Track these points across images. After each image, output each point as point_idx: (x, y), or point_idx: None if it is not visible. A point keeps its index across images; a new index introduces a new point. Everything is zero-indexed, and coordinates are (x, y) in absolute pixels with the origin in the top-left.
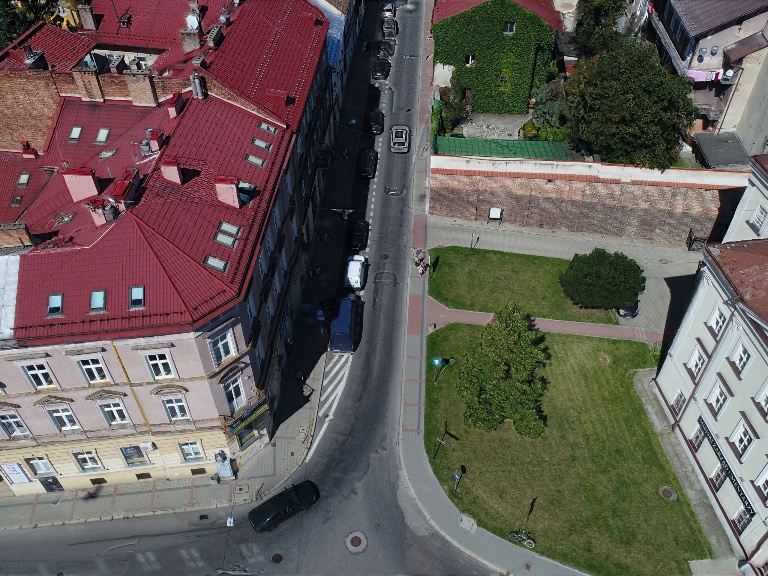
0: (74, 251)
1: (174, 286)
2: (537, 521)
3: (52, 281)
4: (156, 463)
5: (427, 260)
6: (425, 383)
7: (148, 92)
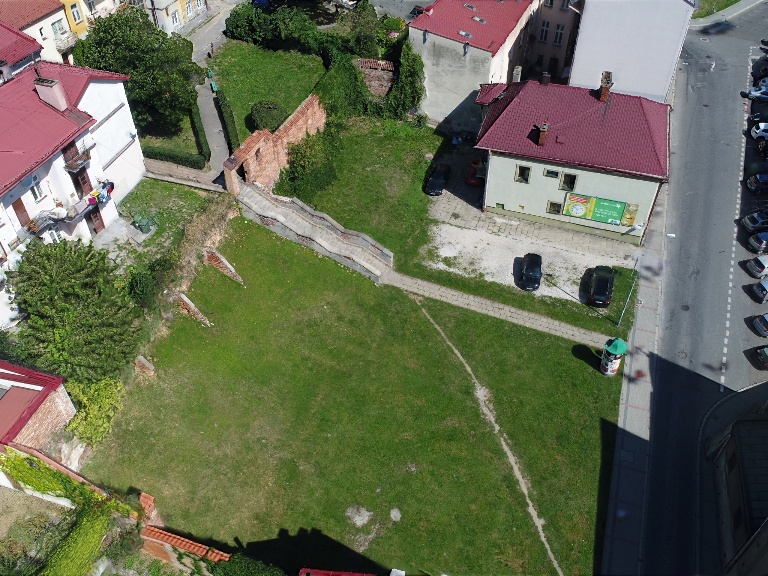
0: None
1: None
2: (704, 7)
3: None
4: None
5: None
6: None
7: None
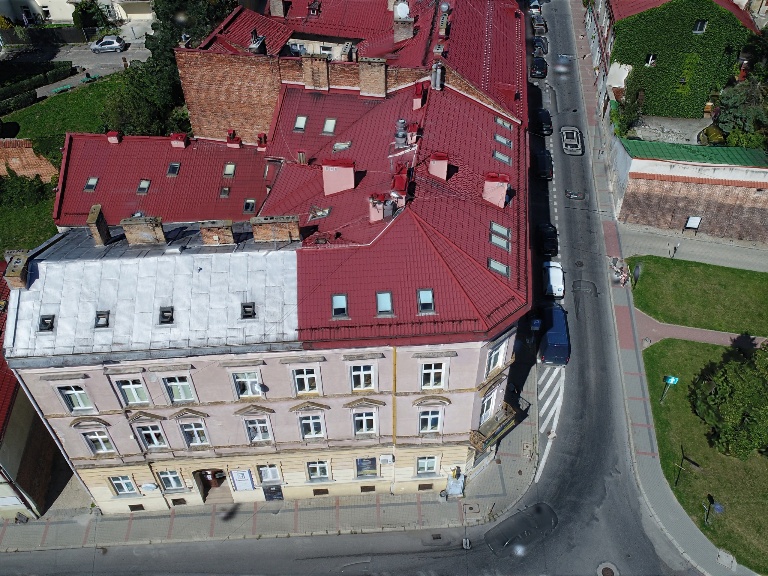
0: (353, 248)
1: (464, 290)
2: None
3: (333, 280)
4: (385, 476)
5: (626, 269)
6: (650, 402)
7: (380, 81)
